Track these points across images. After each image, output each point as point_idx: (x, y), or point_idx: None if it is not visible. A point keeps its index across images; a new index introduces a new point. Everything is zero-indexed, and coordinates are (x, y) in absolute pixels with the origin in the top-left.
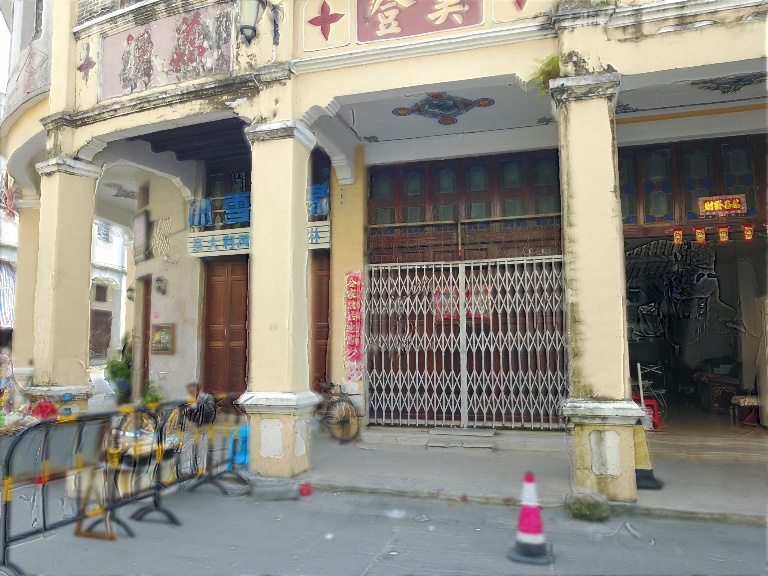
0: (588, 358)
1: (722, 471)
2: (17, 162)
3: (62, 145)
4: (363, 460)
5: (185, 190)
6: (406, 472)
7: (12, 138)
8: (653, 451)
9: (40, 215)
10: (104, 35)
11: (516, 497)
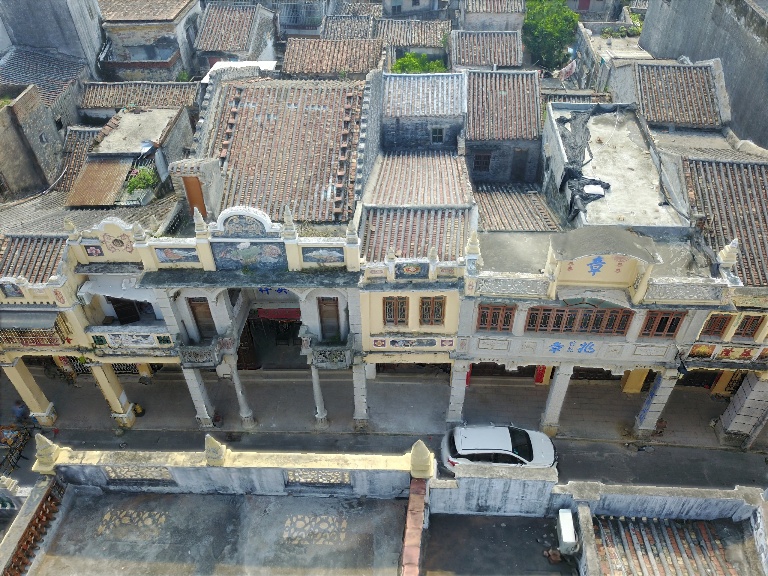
0: (114, 407)
1: (171, 393)
2: None
3: None
4: (75, 401)
5: None
6: (85, 412)
7: None
8: (161, 380)
9: None
10: None
11: (107, 428)
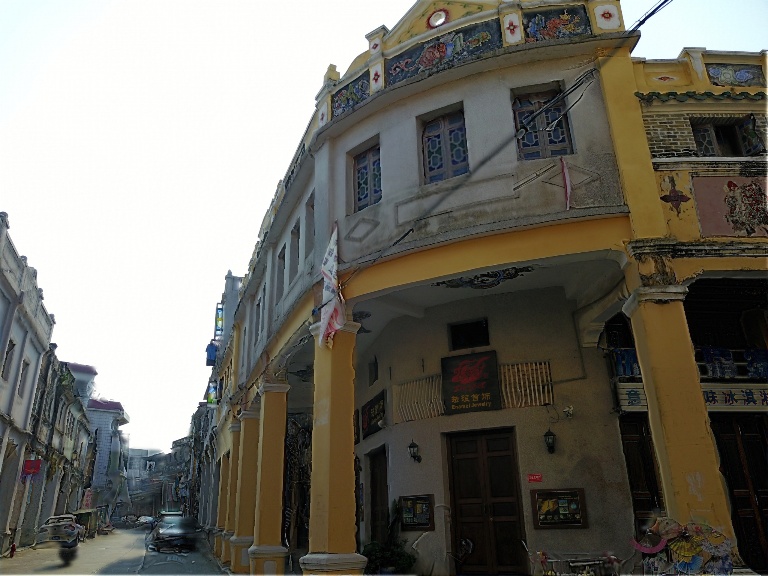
0: None
1: None
2: (459, 276)
3: (674, 273)
4: None
5: (594, 336)
6: None
7: (476, 248)
8: None
9: (652, 347)
10: (694, 174)
11: None
